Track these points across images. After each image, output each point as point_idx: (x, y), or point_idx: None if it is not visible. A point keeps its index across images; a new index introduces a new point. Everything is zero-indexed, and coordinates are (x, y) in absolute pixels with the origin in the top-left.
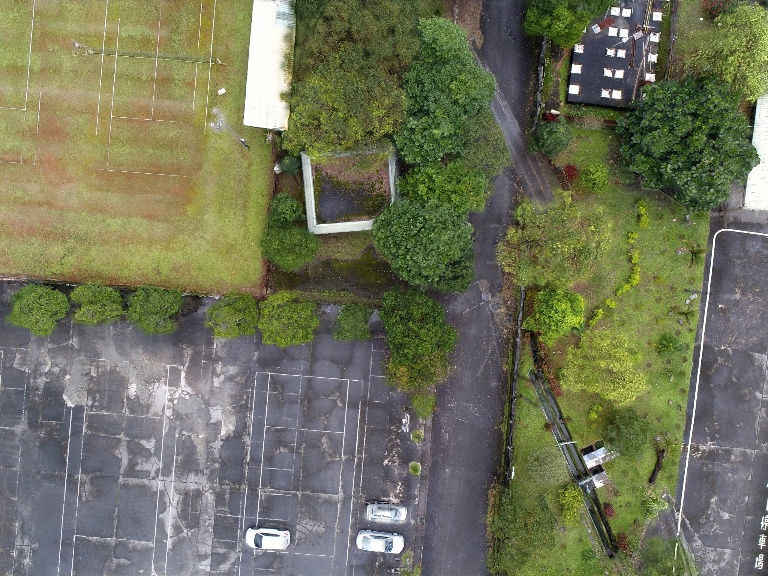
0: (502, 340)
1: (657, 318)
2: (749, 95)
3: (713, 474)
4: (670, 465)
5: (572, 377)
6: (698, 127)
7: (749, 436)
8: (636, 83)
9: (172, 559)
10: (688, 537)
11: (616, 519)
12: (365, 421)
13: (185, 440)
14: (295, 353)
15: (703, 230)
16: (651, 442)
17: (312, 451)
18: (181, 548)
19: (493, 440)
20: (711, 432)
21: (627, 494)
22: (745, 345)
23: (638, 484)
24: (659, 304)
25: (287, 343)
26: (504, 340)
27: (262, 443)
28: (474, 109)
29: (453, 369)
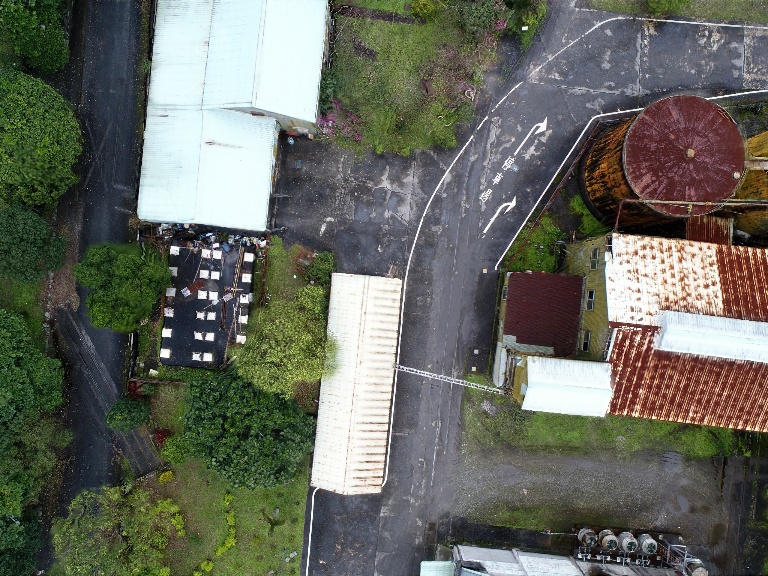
0: None
1: None
2: (280, 394)
3: None
4: None
5: None
6: (228, 429)
7: None
8: (227, 345)
9: None
10: None
11: None
12: None
13: None
14: None
15: (302, 487)
16: None
17: None
18: None
19: None
20: None
21: None
22: None
23: None
24: (260, 562)
25: None
26: None
27: None
28: (10, 413)
29: None
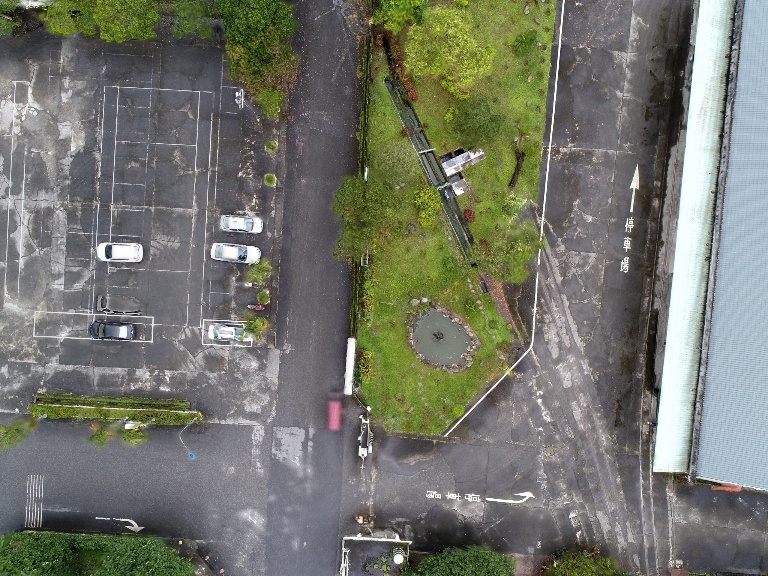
0: (355, 46)
1: (513, 18)
2: None
3: (575, 177)
4: (530, 169)
5: (413, 54)
6: None
7: (610, 136)
8: None
9: (25, 279)
10: (551, 242)
11: (477, 226)
12: (217, 133)
13: (34, 157)
14: (144, 66)
15: None
16: (510, 145)
17: (164, 165)
18: (34, 268)
19: (349, 149)
20: (571, 133)
21: (487, 200)
22: (604, 43)
23: (498, 189)
24: (514, 4)
25: (122, 31)
26: (357, 46)
27: (113, 158)
28: None
29: (306, 77)
